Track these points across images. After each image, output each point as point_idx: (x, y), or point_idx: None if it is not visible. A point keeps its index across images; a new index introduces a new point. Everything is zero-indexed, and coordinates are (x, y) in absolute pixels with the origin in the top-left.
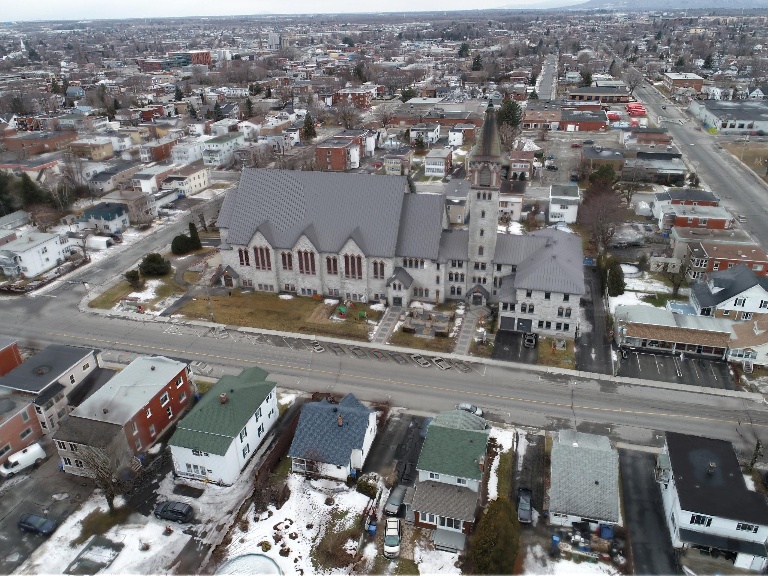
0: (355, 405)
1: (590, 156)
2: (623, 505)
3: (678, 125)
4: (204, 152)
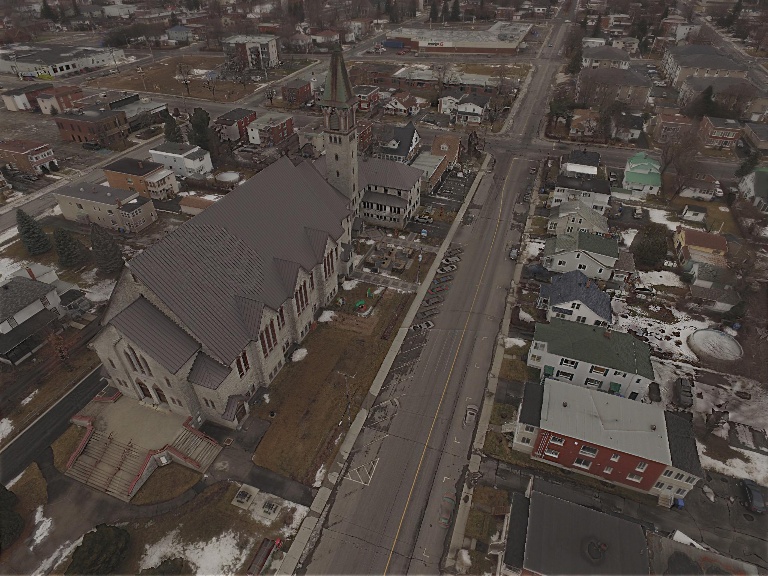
0: None
1: (90, 120)
2: None
3: (0, 82)
4: None
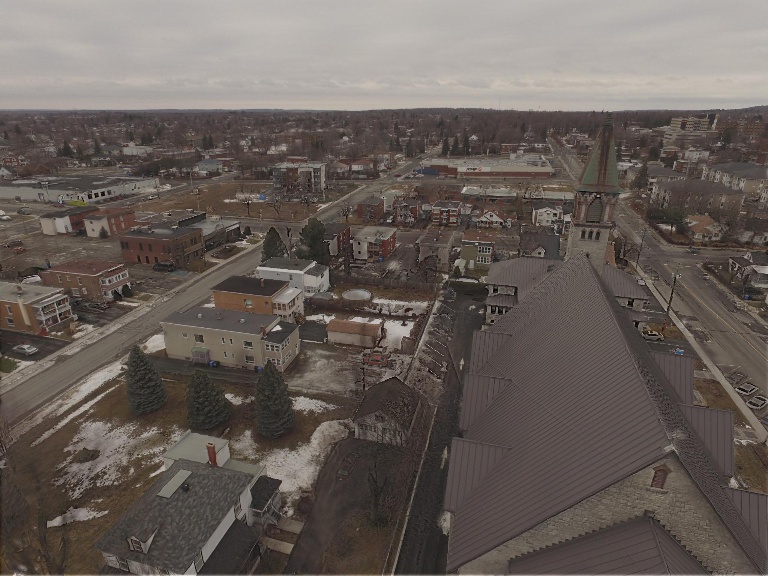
0: None
1: (166, 237)
2: None
3: None
4: None
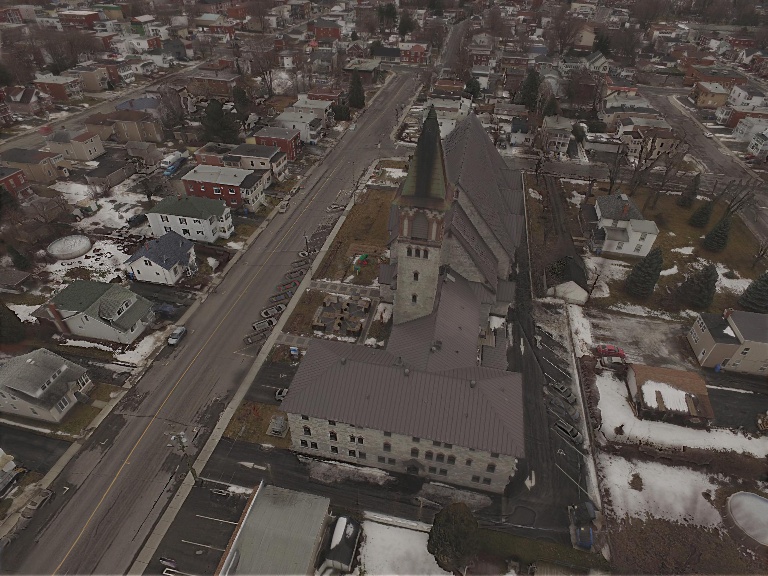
0: (183, 261)
1: None
2: (3, 425)
3: None
4: (757, 134)
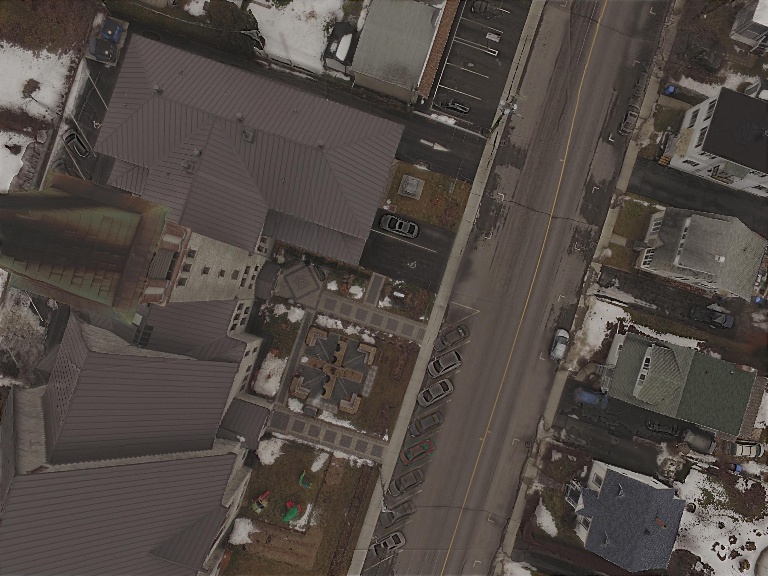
0: (592, 497)
1: None
2: None
3: None
4: None
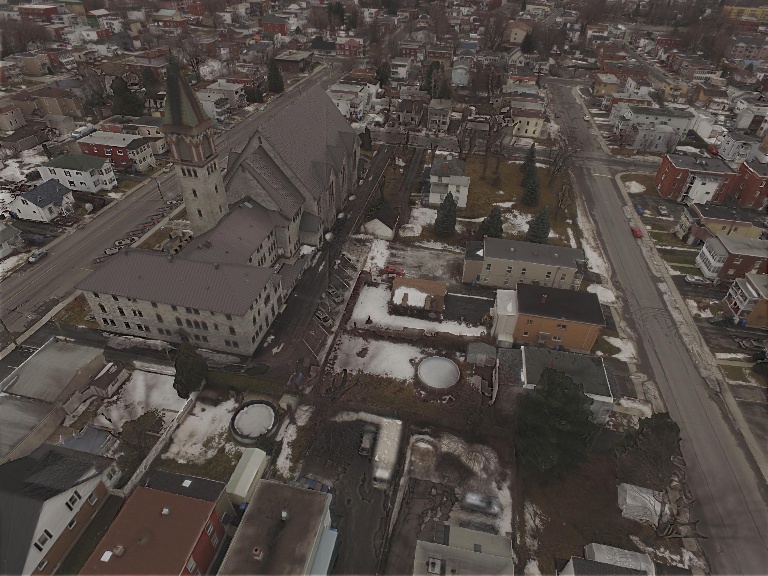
0: (57, 202)
1: None
2: None
3: None
4: (620, 116)
